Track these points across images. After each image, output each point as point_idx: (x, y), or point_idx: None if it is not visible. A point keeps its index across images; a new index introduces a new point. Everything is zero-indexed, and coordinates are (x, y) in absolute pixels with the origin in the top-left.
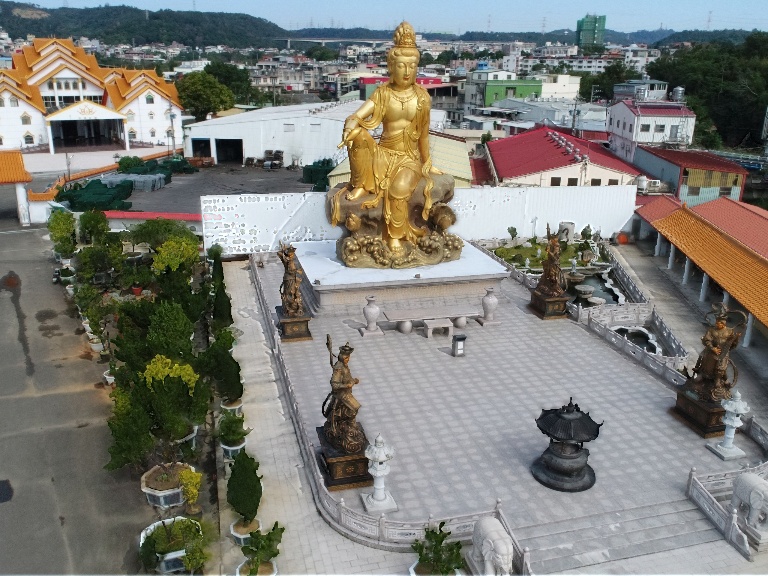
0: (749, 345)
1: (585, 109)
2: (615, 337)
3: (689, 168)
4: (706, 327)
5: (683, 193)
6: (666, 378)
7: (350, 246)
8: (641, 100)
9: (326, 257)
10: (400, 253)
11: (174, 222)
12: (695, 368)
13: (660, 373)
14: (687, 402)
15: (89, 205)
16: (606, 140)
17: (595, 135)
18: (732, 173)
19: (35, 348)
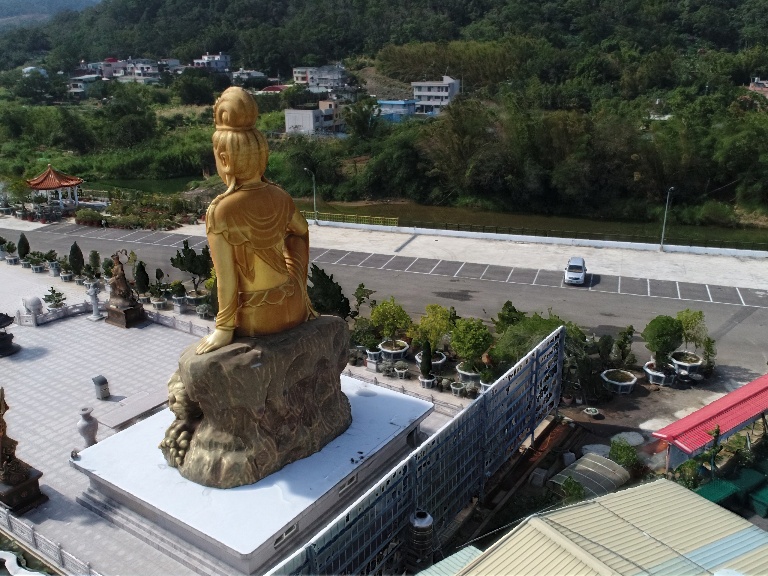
0: None
1: None
2: None
3: None
4: None
5: None
6: None
7: None
8: None
9: None
10: None
11: None
12: None
13: None
14: None
15: None
16: None
17: None
18: None
19: (420, 315)
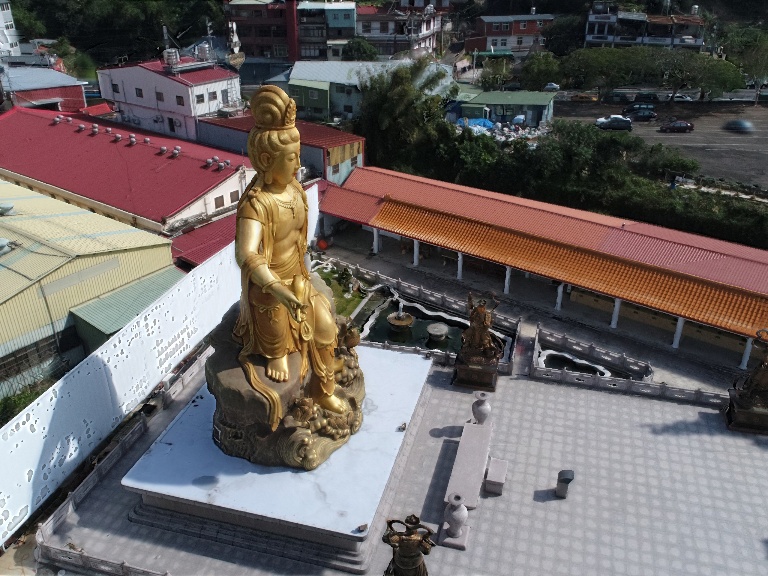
0: (617, 325)
1: (8, 64)
2: (582, 377)
3: (330, 148)
4: (563, 321)
5: (329, 174)
6: (667, 396)
7: (309, 443)
8: (176, 65)
9: (244, 474)
10: (350, 410)
11: None
12: (745, 386)
13: (658, 394)
14: (751, 416)
15: None
16: (48, 98)
17: (32, 95)
18: (356, 142)
19: None
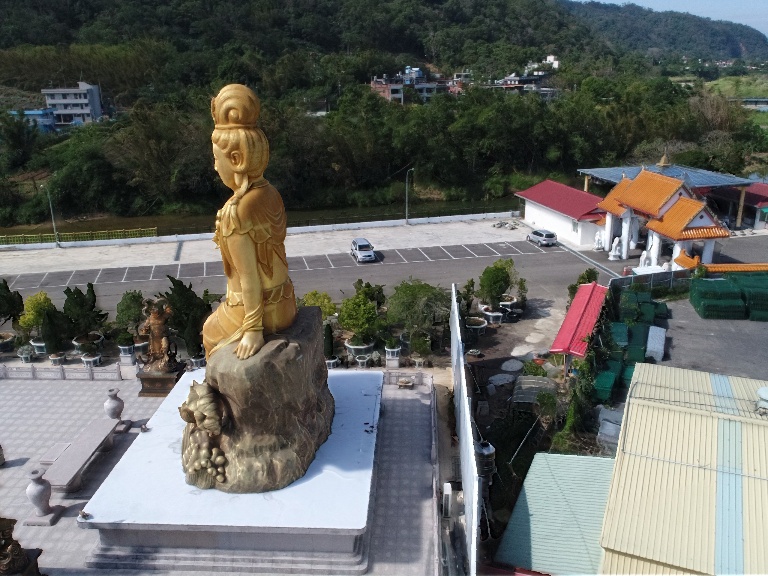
0: None
1: None
2: None
3: None
4: None
5: None
6: None
7: None
8: None
9: None
10: None
11: (418, 295)
12: None
13: None
14: None
15: (694, 288)
16: None
17: None
18: None
19: None
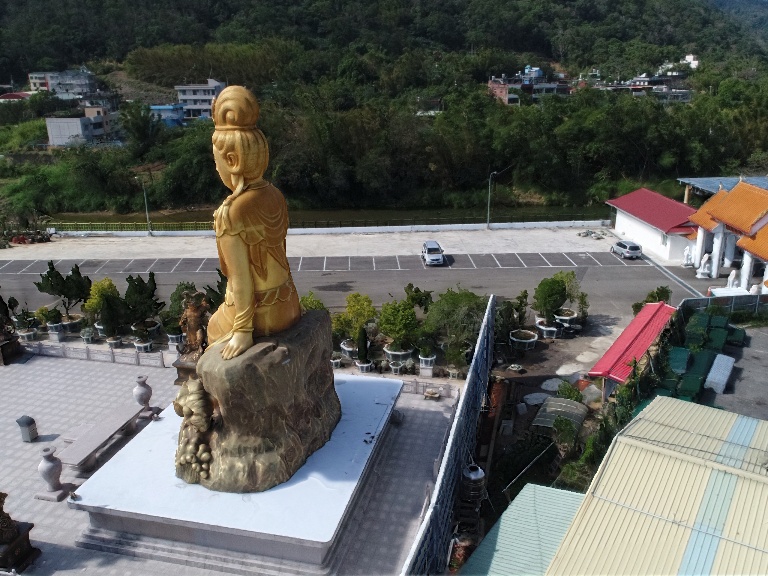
0: None
1: None
2: None
3: None
4: None
5: None
6: None
7: None
8: None
9: None
10: None
11: None
12: None
13: None
14: None
15: None
16: None
17: None
18: None
19: None
